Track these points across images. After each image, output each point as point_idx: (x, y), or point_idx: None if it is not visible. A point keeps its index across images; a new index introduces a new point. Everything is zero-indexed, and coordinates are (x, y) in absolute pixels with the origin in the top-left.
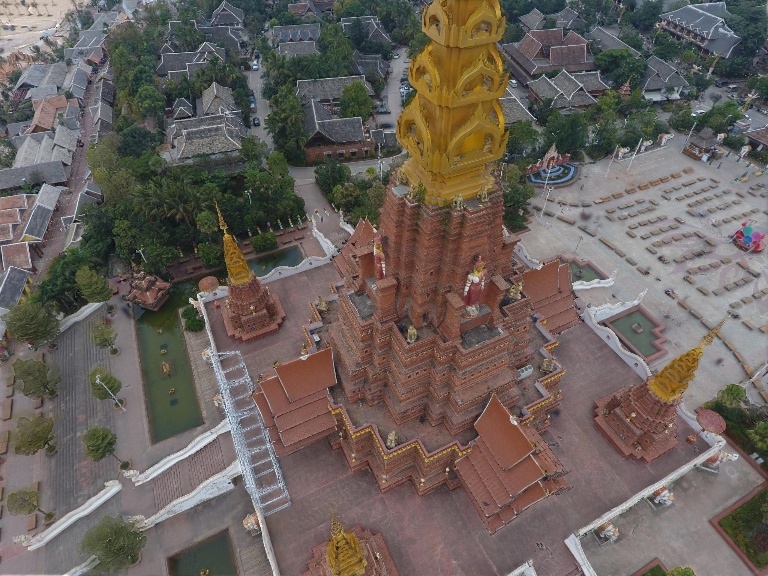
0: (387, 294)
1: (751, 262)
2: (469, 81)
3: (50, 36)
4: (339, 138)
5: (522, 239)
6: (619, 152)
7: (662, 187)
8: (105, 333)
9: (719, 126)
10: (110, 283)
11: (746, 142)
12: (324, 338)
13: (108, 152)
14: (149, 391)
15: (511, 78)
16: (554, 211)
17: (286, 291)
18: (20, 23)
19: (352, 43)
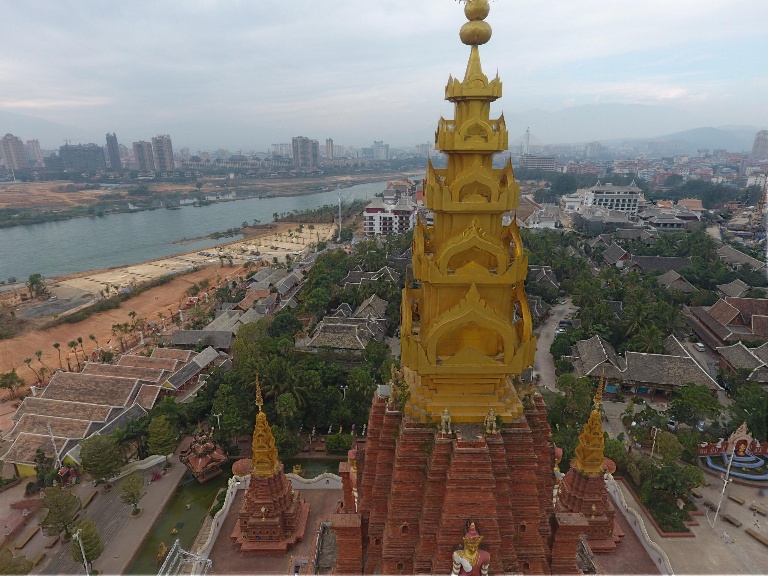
0: (347, 540)
1: None
2: (457, 253)
3: (291, 254)
4: None
5: (677, 546)
6: None
7: None
8: (132, 486)
9: None
10: (187, 441)
11: None
12: None
13: (255, 328)
14: (129, 573)
15: (698, 341)
16: (741, 519)
17: (324, 506)
18: (283, 246)
19: None
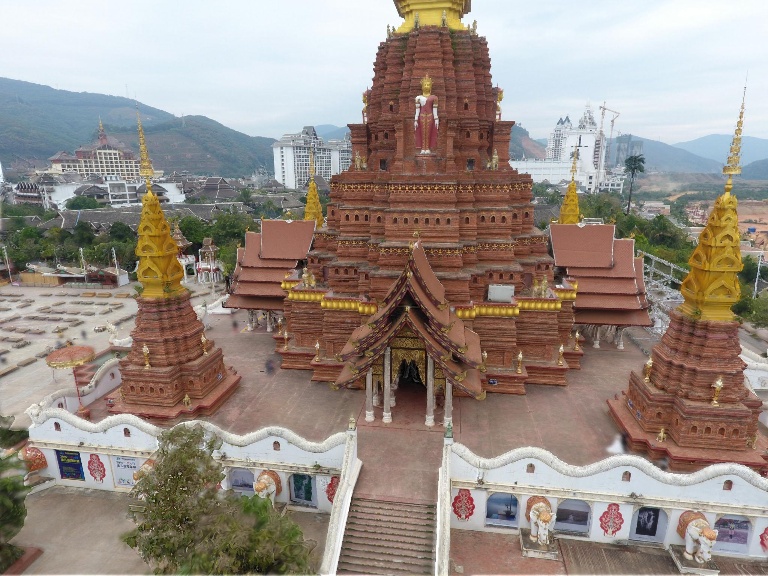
0: None
1: None
2: None
3: None
4: None
5: None
6: None
7: None
8: None
9: None
10: None
11: None
12: (552, 259)
13: None
14: None
15: None
16: None
17: (607, 455)
18: None
19: None
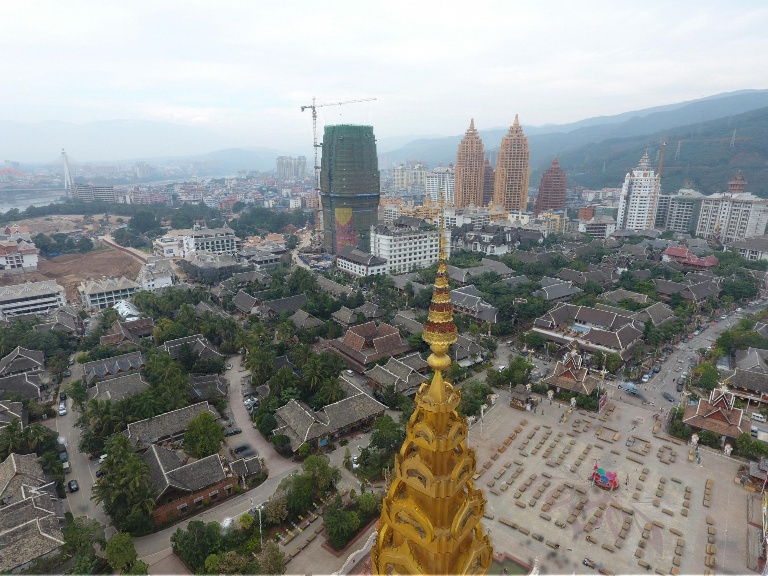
0: None
1: (619, 500)
2: None
3: None
4: (195, 485)
5: None
6: (467, 421)
7: (515, 445)
8: None
9: (523, 379)
10: None
11: (547, 387)
12: None
13: None
14: None
15: None
16: None
17: None
18: None
19: (182, 366)
